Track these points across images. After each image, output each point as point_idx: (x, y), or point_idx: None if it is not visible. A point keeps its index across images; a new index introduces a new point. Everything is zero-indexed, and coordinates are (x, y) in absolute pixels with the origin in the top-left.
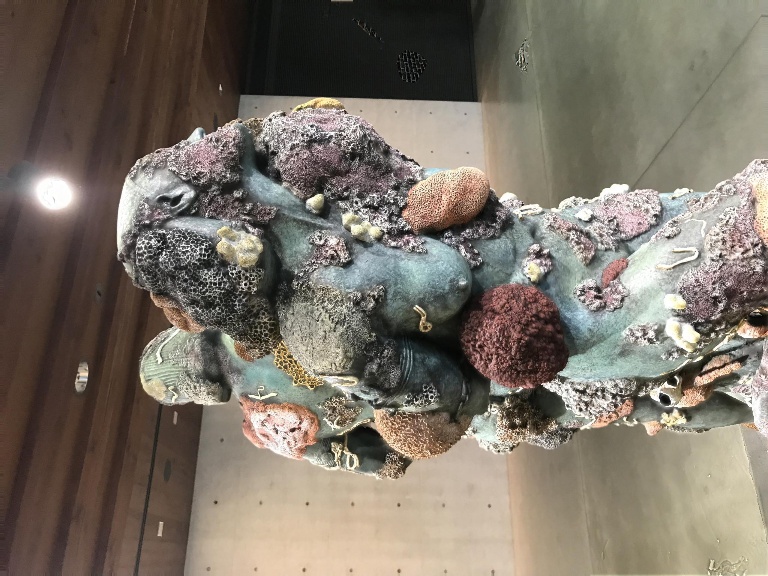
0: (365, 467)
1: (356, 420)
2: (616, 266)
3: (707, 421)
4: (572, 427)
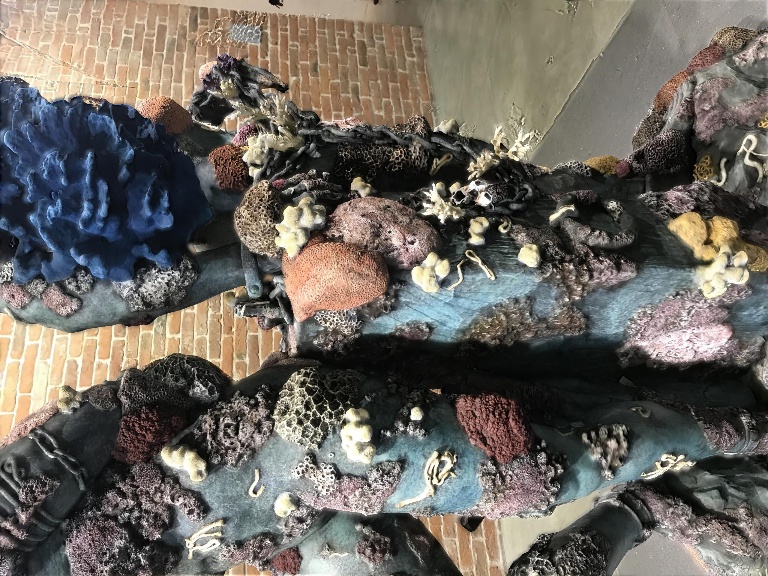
0: None
1: None
2: None
3: None
4: None
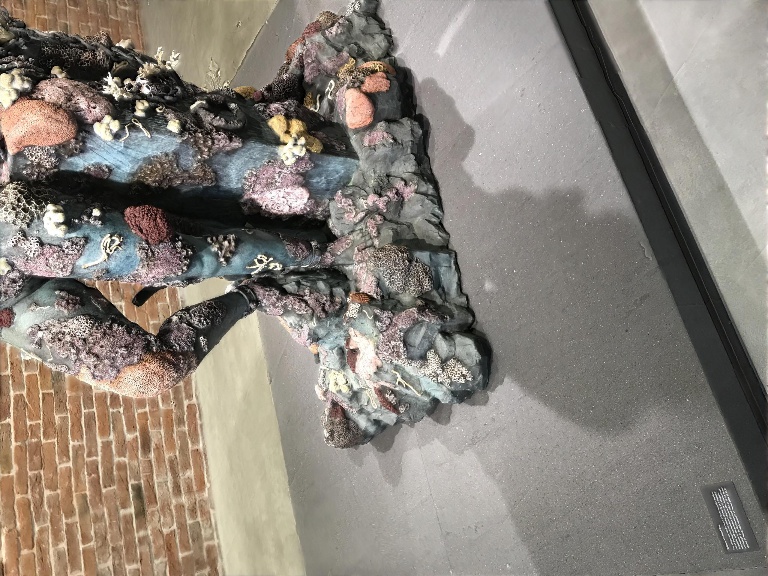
0: None
1: None
2: (5, 318)
3: None
4: None
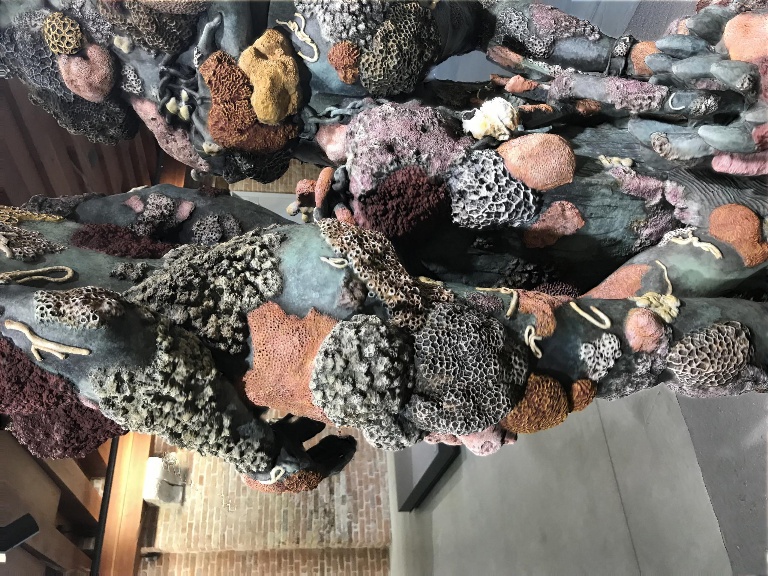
0: (20, 288)
1: (43, 264)
2: None
3: (712, 303)
4: (487, 308)
